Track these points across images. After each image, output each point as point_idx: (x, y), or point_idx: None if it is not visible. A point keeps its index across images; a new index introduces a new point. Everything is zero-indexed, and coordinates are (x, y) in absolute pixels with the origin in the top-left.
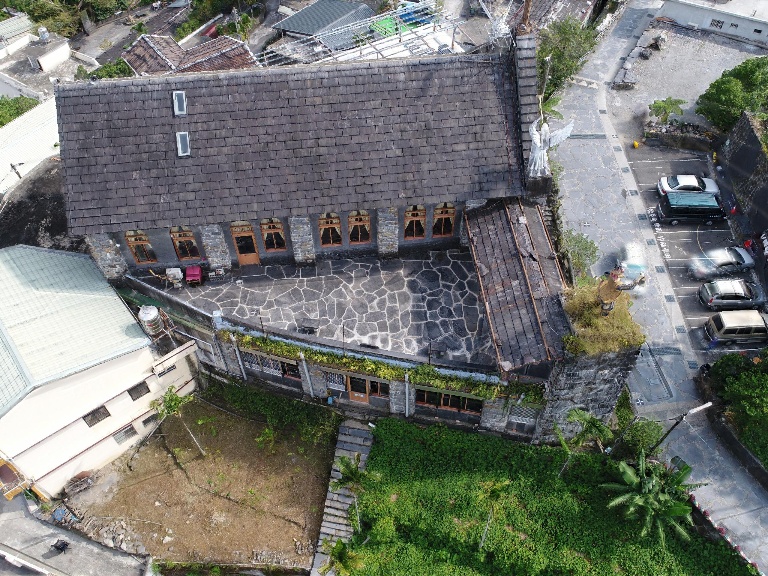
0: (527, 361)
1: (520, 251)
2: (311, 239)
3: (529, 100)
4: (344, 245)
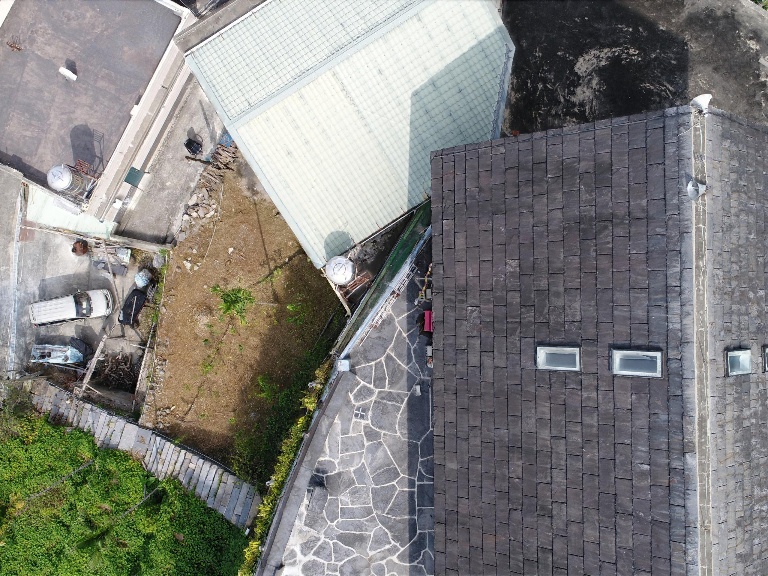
0: None
1: None
2: None
3: None
4: None
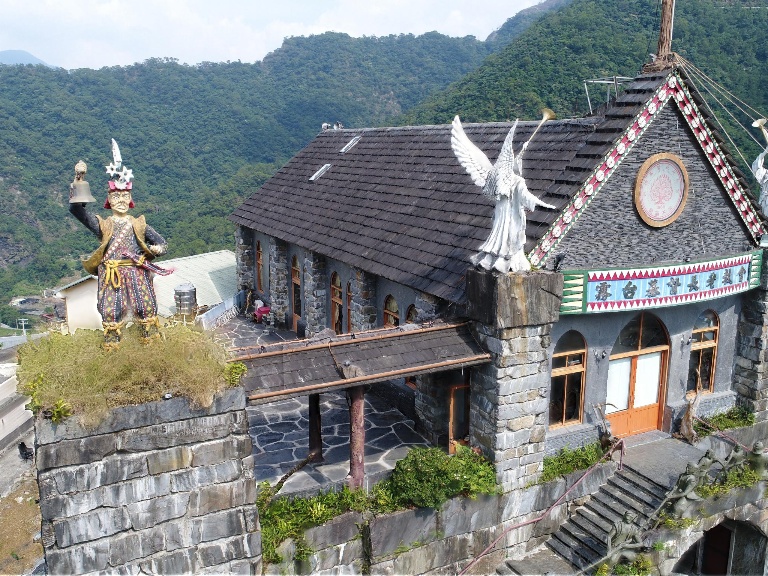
0: None
1: None
2: (314, 303)
3: (582, 163)
4: None
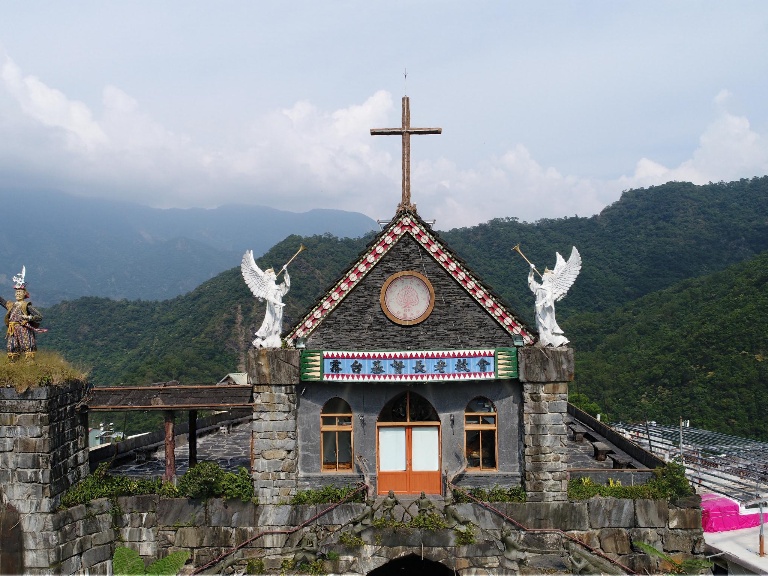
0: None
1: None
2: None
3: None
4: None
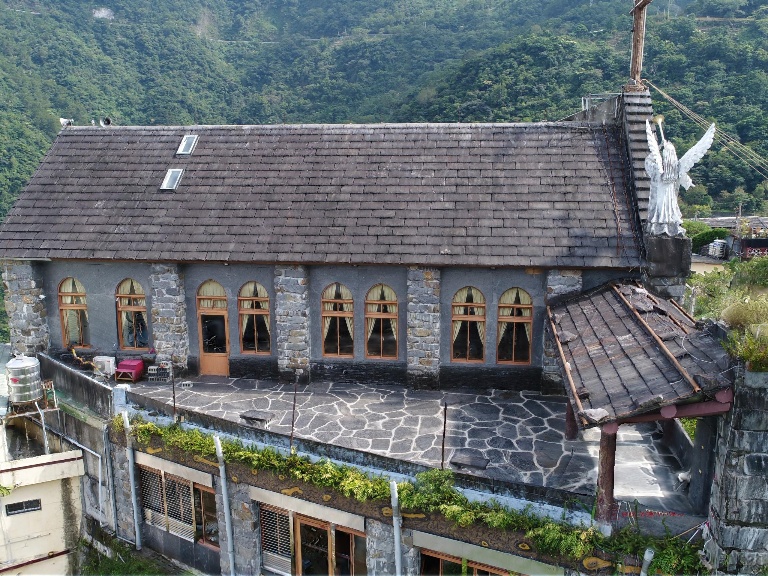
0: (644, 399)
1: (634, 305)
2: (305, 325)
3: (645, 155)
4: (356, 357)
